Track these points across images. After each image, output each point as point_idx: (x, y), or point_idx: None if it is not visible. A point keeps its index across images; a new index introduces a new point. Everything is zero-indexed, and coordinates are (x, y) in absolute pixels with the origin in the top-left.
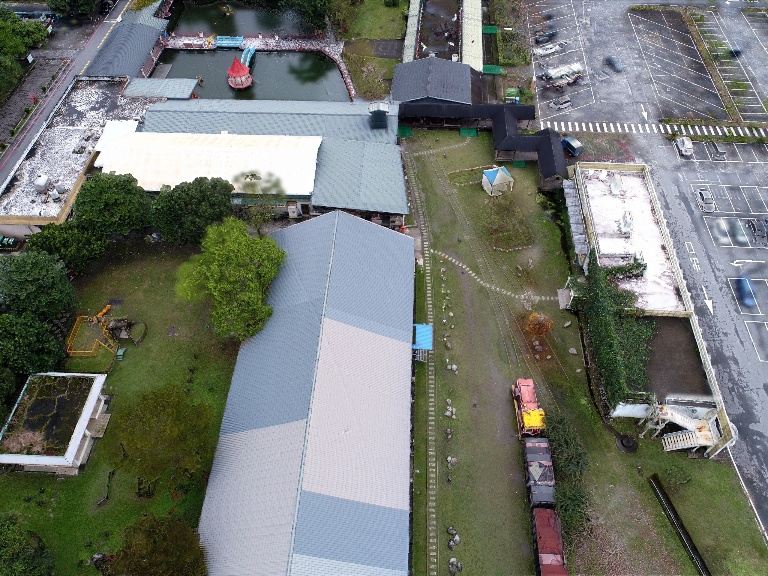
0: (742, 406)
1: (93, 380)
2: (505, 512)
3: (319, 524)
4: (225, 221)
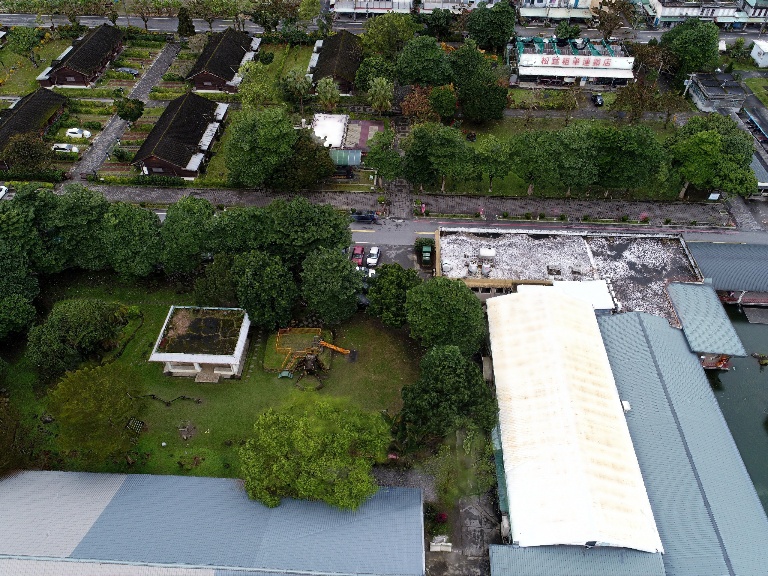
0: None
1: (232, 354)
2: None
3: None
4: (423, 428)
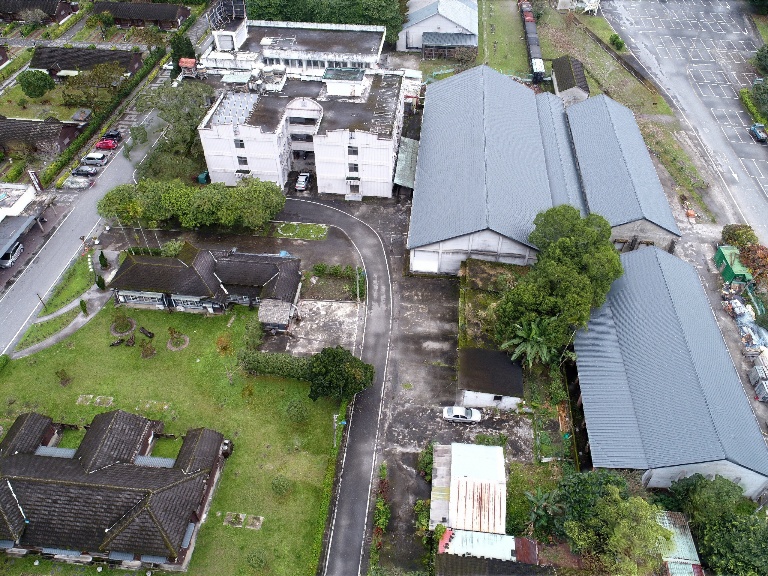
0: (612, 8)
1: None
2: (513, 22)
3: None
4: None
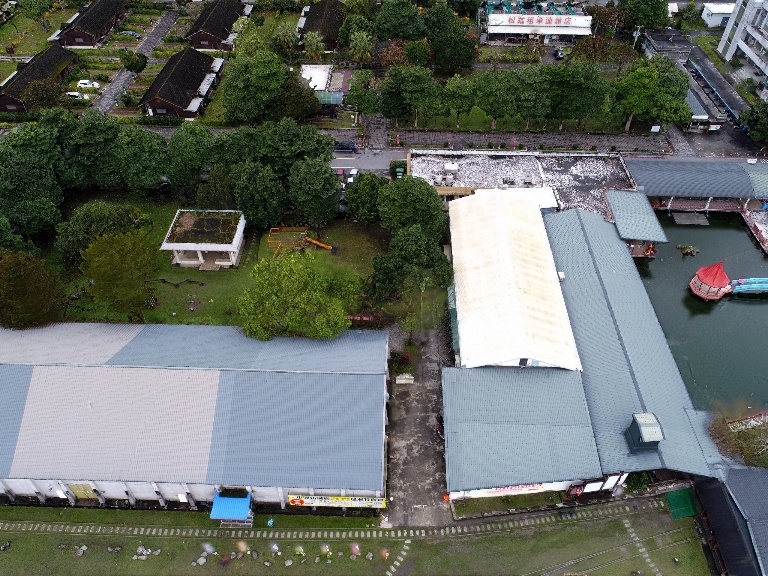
0: None
1: None
2: None
3: (4, 385)
4: (390, 286)
